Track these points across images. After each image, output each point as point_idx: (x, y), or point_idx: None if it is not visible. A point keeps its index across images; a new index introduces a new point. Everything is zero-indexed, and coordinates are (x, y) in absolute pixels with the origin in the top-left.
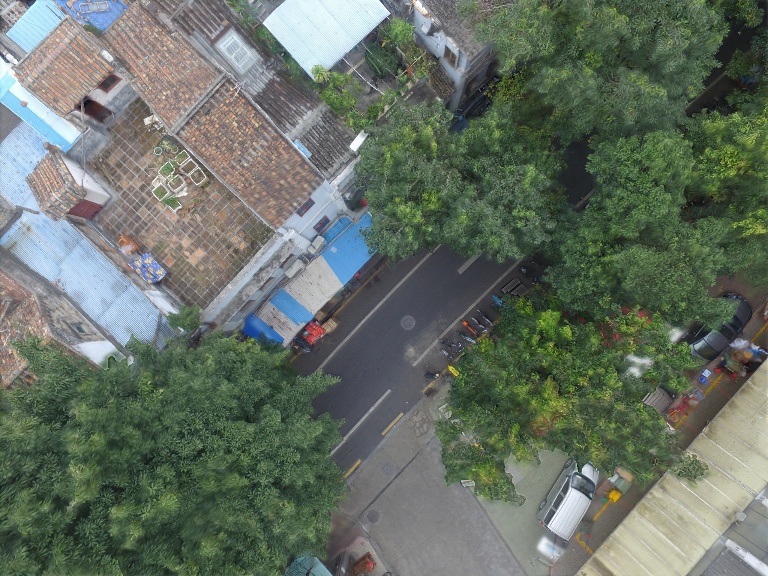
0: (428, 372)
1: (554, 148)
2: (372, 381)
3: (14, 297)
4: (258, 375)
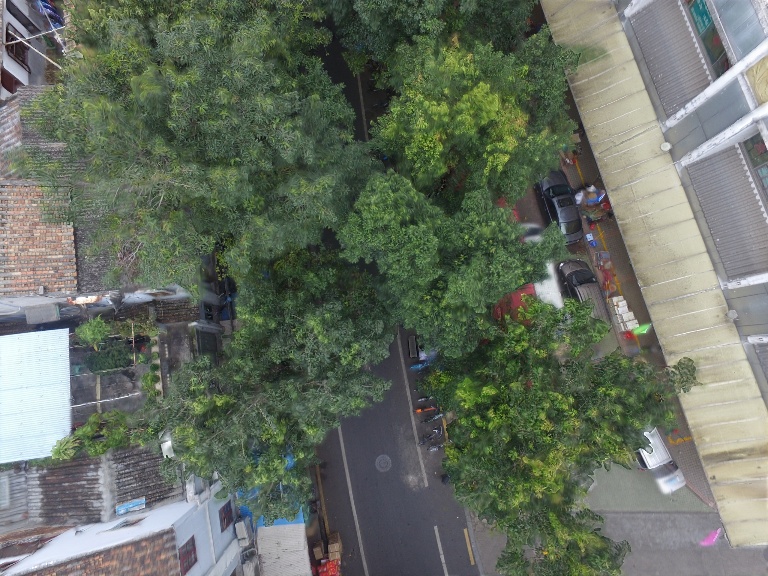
0: (442, 477)
1: (315, 253)
2: (416, 539)
3: None
4: None
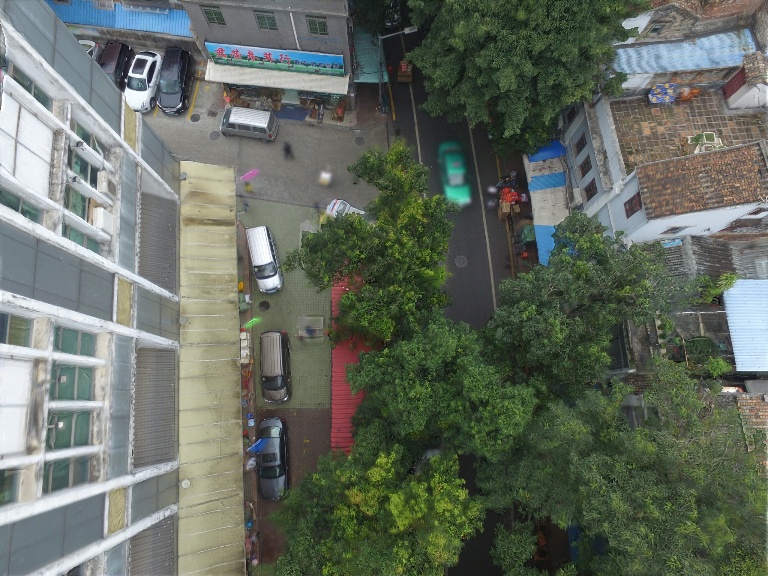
0: None
1: (530, 419)
2: None
3: (709, 5)
4: None
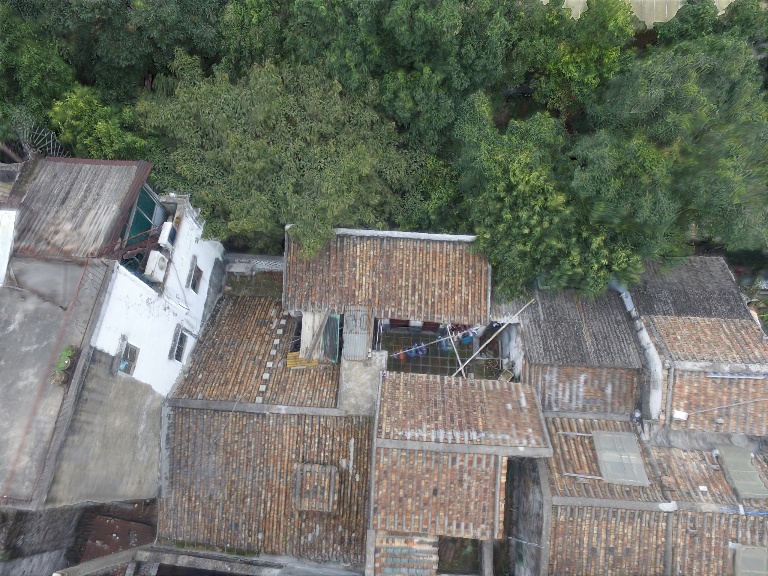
0: None
1: None
2: None
3: None
4: None
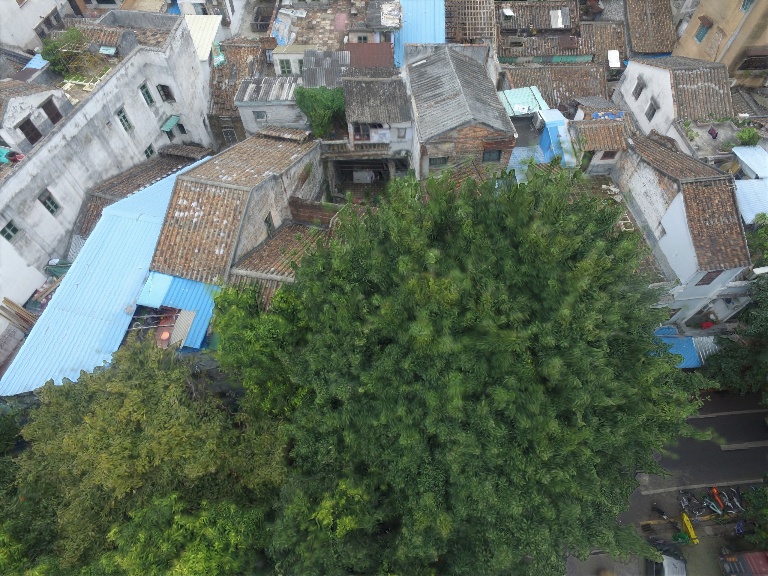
0: None
1: None
2: None
3: None
4: None
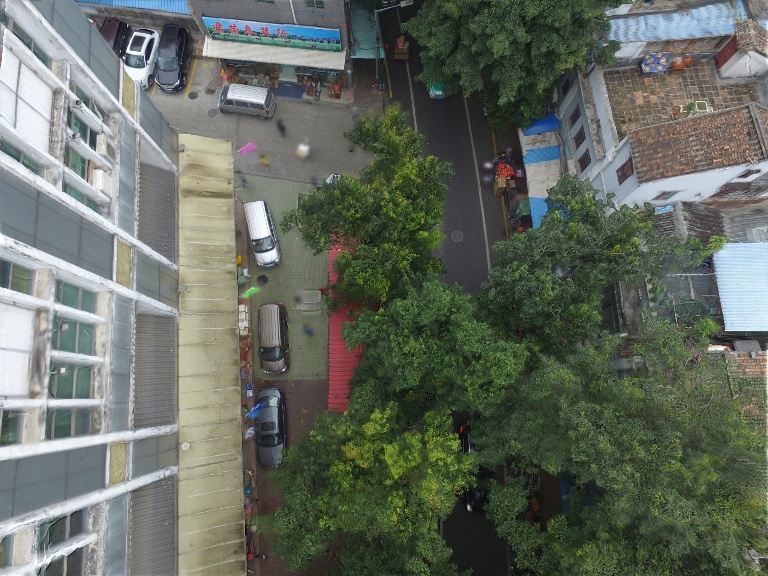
0: None
1: None
2: None
3: None
4: (543, 61)
